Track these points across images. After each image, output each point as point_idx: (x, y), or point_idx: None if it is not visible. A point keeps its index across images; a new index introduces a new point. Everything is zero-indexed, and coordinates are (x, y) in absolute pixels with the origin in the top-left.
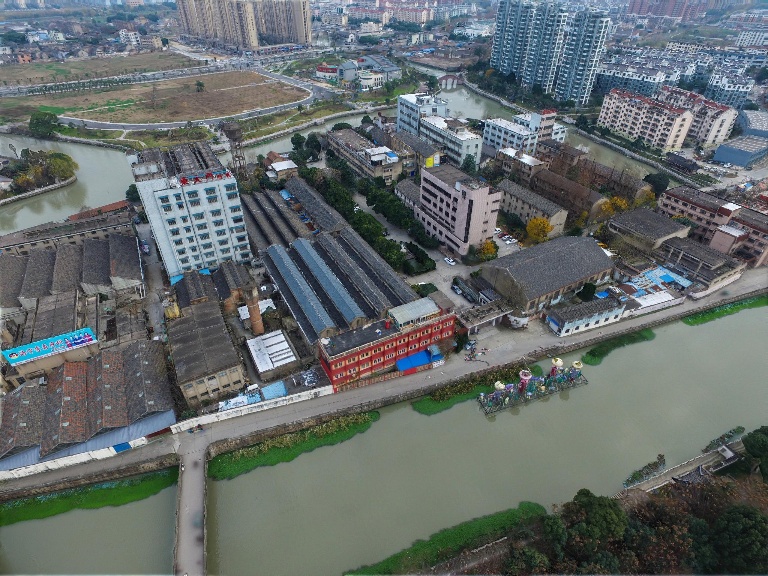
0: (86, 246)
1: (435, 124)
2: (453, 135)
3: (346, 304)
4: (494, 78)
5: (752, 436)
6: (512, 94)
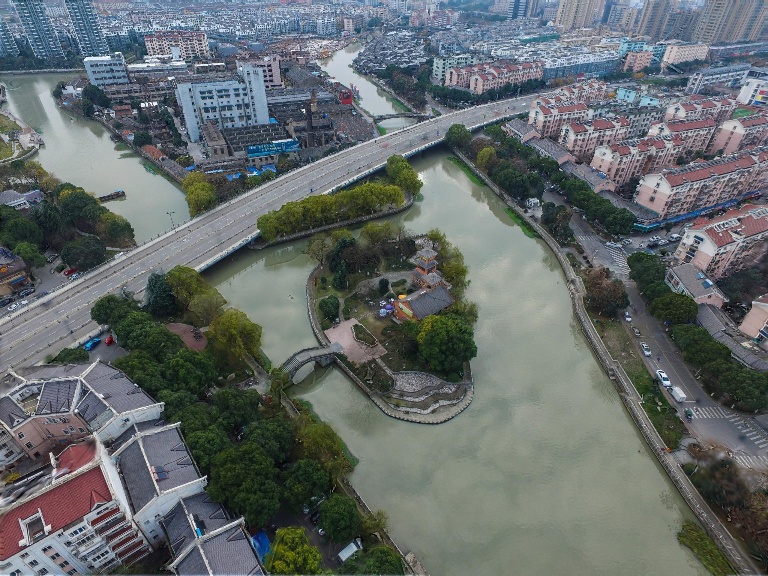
0: (236, 131)
1: (148, 65)
2: (173, 65)
3: (319, 93)
4: (13, 58)
5: (381, 74)
6: (61, 62)
